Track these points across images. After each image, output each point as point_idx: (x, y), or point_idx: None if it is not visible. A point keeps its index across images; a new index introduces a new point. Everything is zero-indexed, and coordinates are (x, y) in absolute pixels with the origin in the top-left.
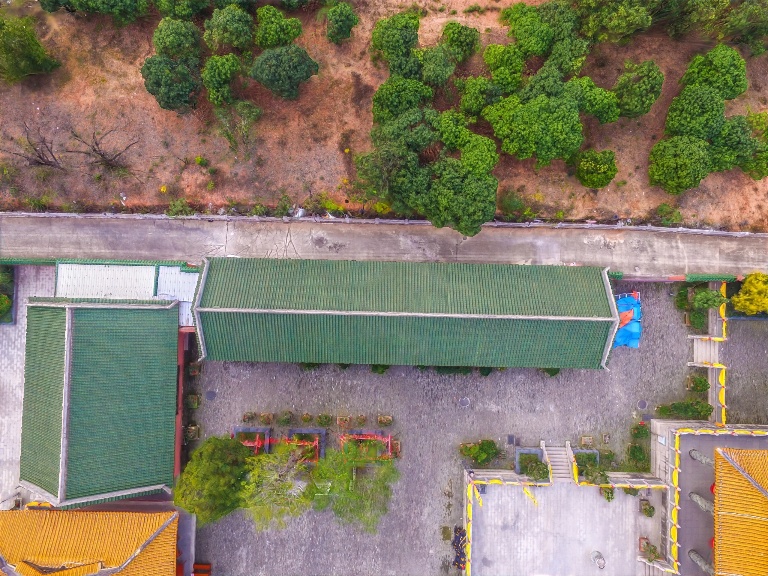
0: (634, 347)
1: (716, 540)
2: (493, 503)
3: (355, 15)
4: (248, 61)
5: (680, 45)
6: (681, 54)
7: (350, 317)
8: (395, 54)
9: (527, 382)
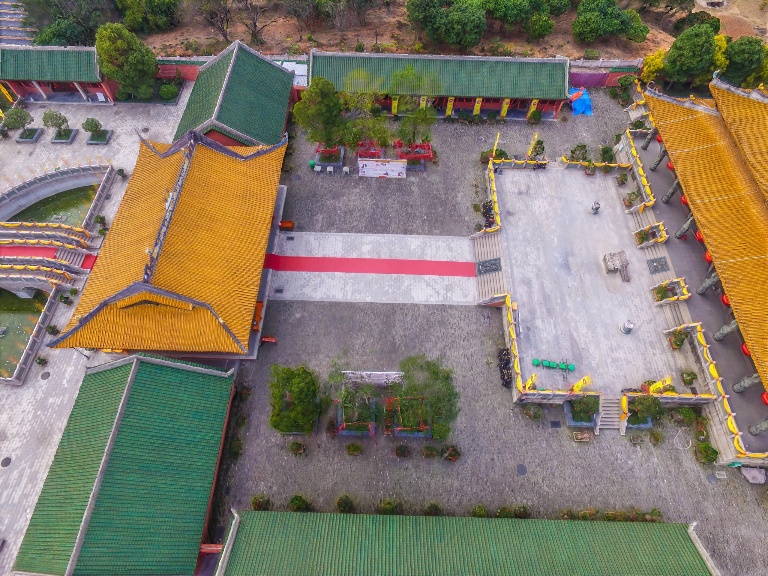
0: (590, 115)
1: (662, 137)
2: (509, 180)
3: None
4: None
5: None
6: None
7: (405, 60)
8: None
9: (522, 130)
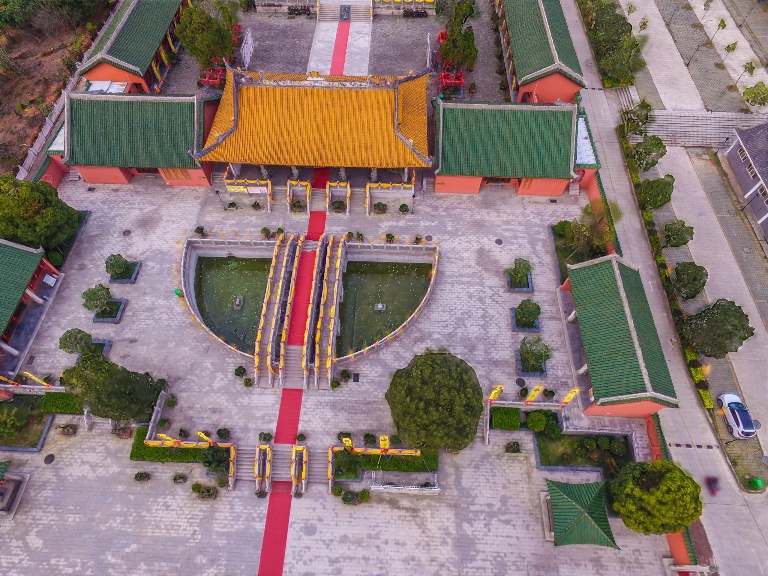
0: None
1: None
2: None
3: None
4: None
5: None
6: None
7: (136, 8)
8: (2, 15)
9: None
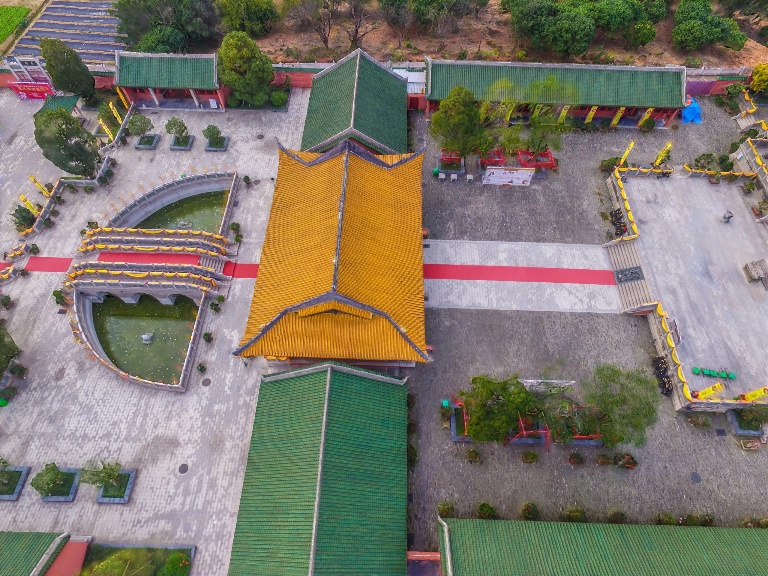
0: (699, 123)
1: None
2: (635, 188)
3: (481, 14)
4: (436, 6)
5: (667, 19)
6: (670, 21)
7: (522, 68)
8: None
9: (634, 138)
